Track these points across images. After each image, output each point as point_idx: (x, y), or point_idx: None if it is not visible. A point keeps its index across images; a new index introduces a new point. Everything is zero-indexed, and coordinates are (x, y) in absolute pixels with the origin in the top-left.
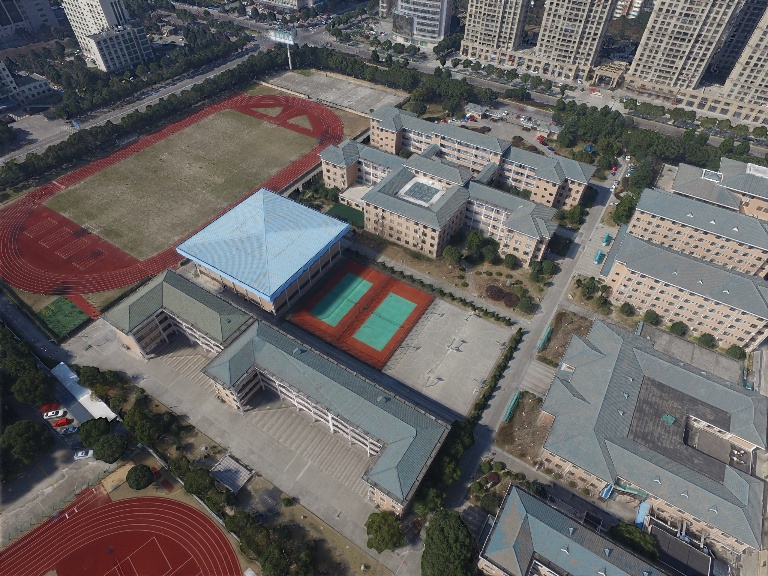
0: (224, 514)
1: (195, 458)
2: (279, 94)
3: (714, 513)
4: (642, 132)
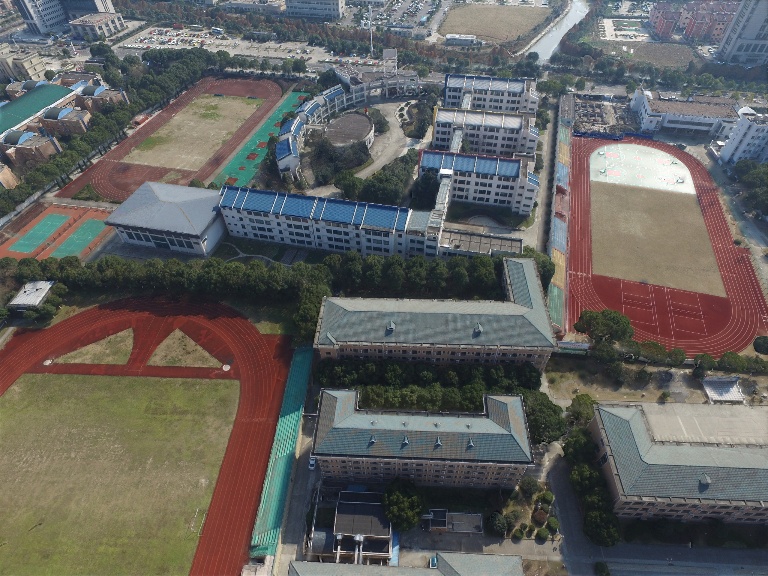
0: (690, 366)
1: (759, 386)
2: None
3: (337, 575)
4: None
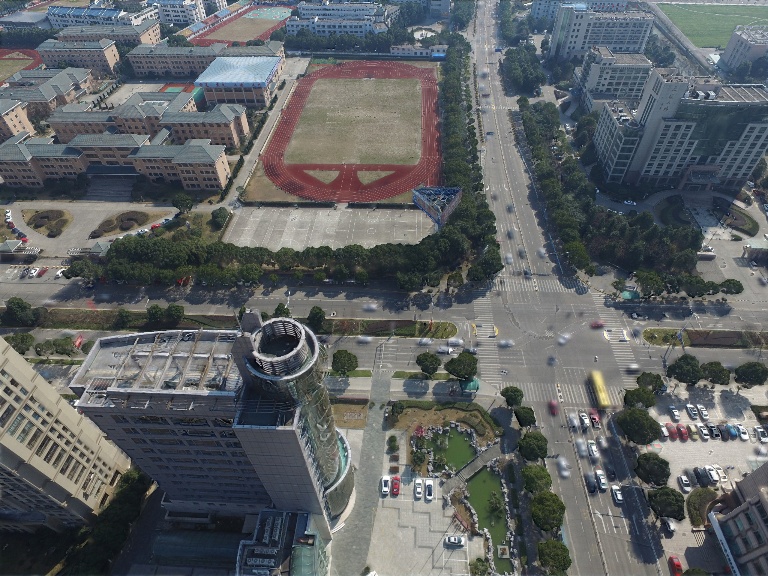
0: None
1: None
2: (392, 199)
3: None
4: None
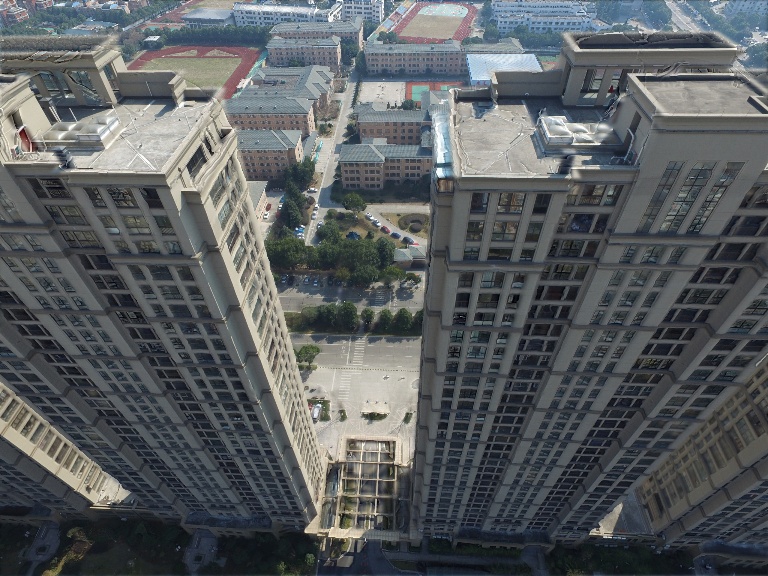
0: None
1: None
2: None
3: None
4: (295, 242)
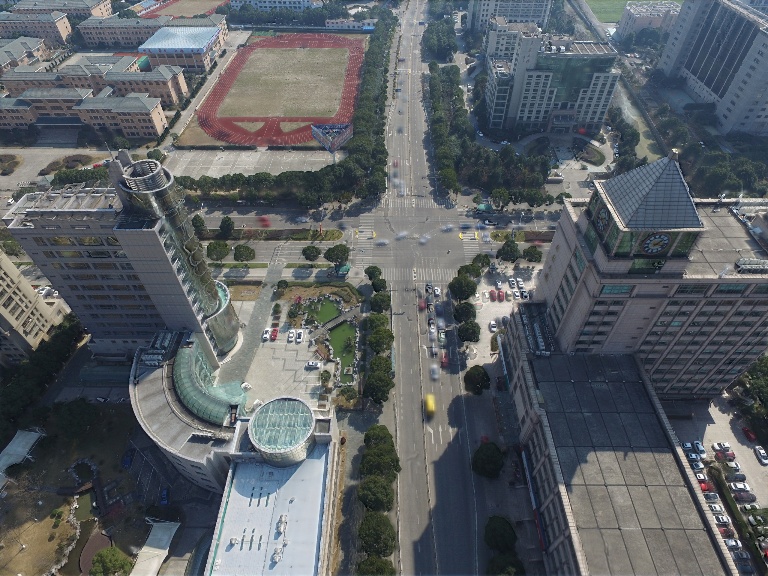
0: None
1: None
2: (306, 143)
3: None
4: None
